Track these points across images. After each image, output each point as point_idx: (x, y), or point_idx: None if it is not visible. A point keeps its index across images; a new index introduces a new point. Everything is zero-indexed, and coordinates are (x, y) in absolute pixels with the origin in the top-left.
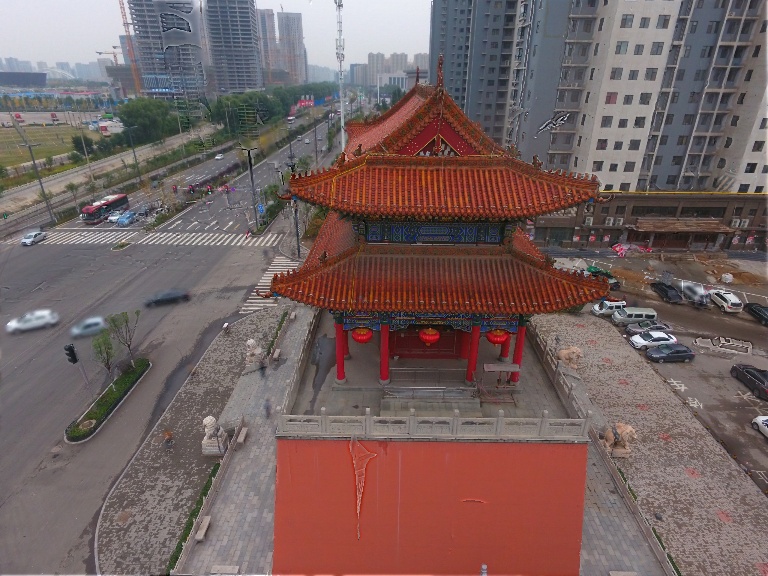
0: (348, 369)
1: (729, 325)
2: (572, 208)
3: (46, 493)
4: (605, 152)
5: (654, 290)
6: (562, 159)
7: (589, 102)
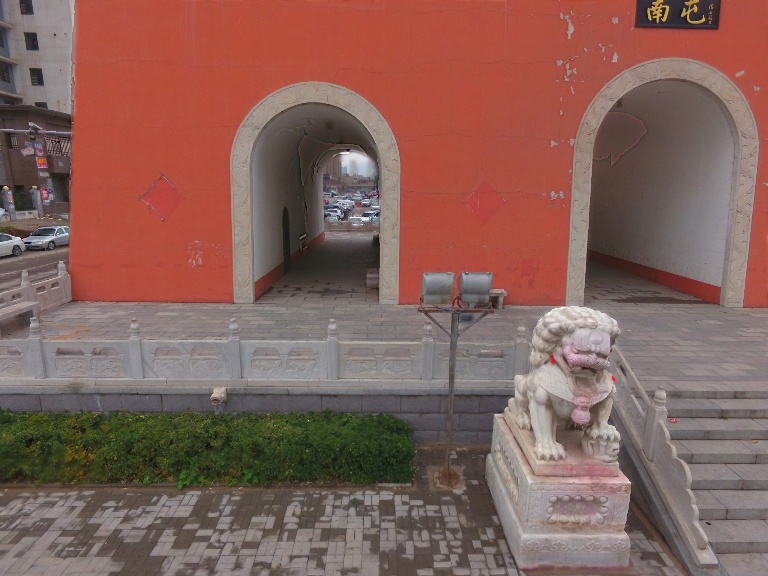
0: None
1: None
2: None
3: None
4: None
5: None
6: (1, 72)
7: None
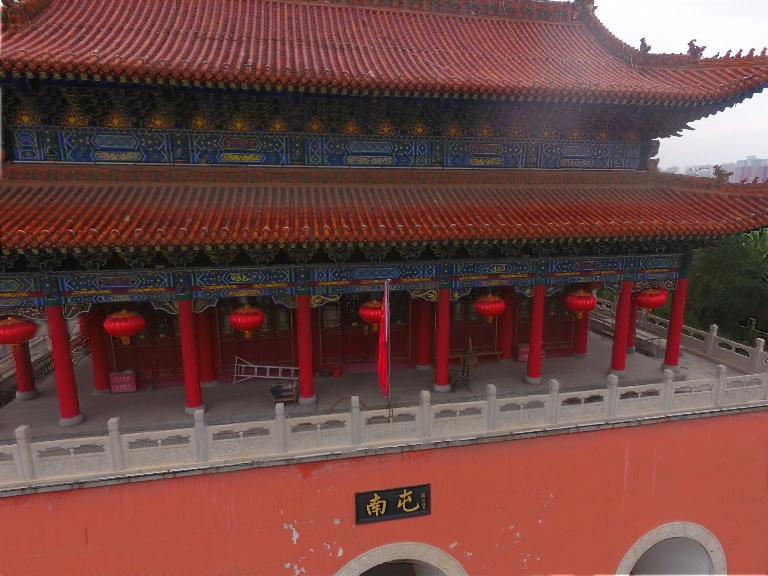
0: (639, 370)
1: None
2: None
3: None
4: None
5: None
6: None
7: None
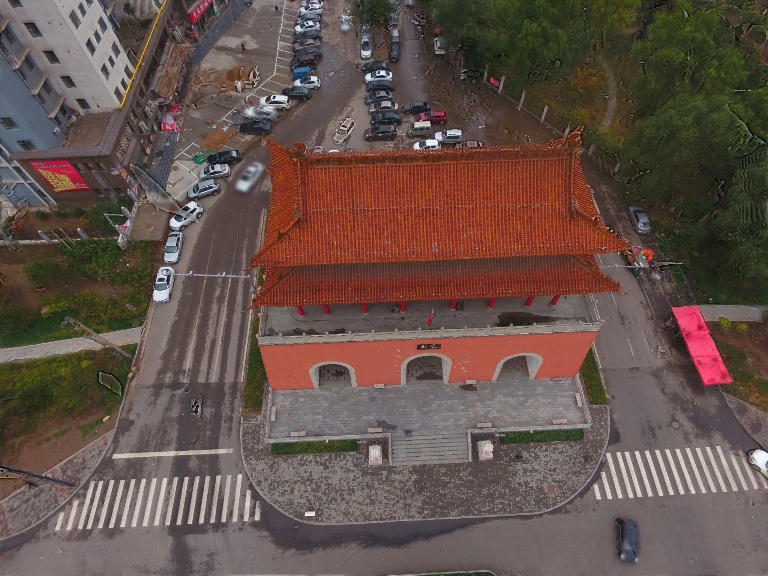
0: (539, 303)
1: (305, 116)
2: (126, 129)
3: (548, 568)
4: (97, 53)
5: (248, 134)
6: (45, 89)
7: (26, 6)
